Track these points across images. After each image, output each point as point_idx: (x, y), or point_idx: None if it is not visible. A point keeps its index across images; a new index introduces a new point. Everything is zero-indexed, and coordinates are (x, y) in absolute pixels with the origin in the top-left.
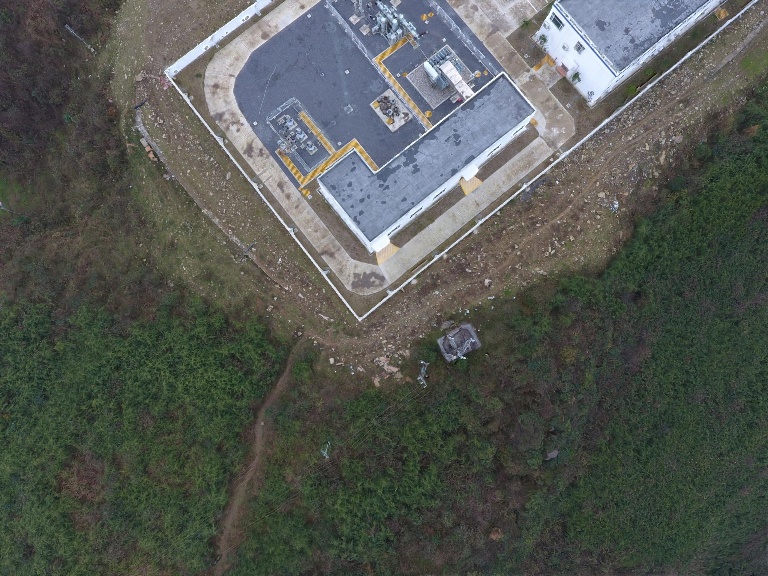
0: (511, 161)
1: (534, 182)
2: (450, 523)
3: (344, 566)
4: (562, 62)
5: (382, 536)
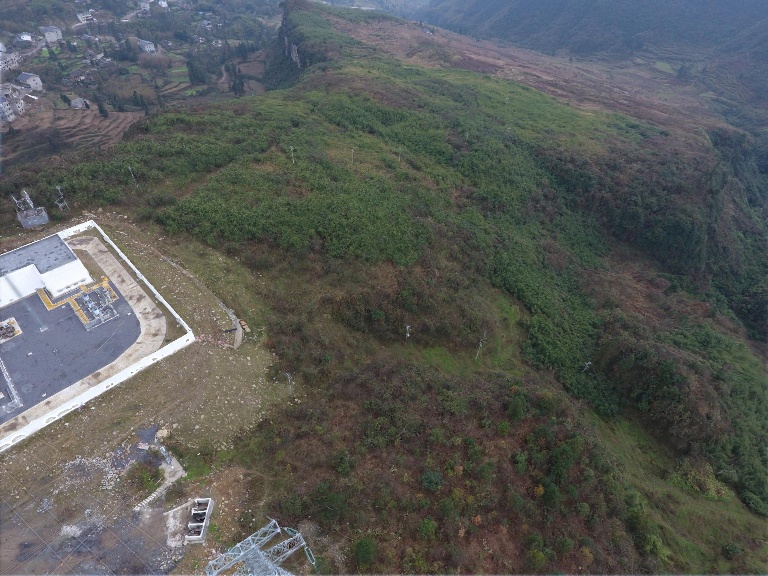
0: None
1: None
2: (76, 157)
3: None
4: None
5: None
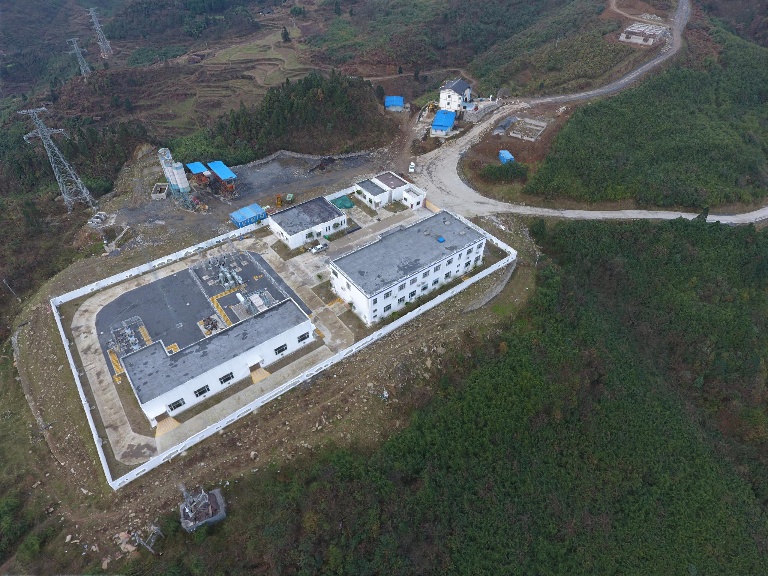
0: (298, 360)
1: (315, 375)
2: None
3: None
4: (343, 298)
5: None
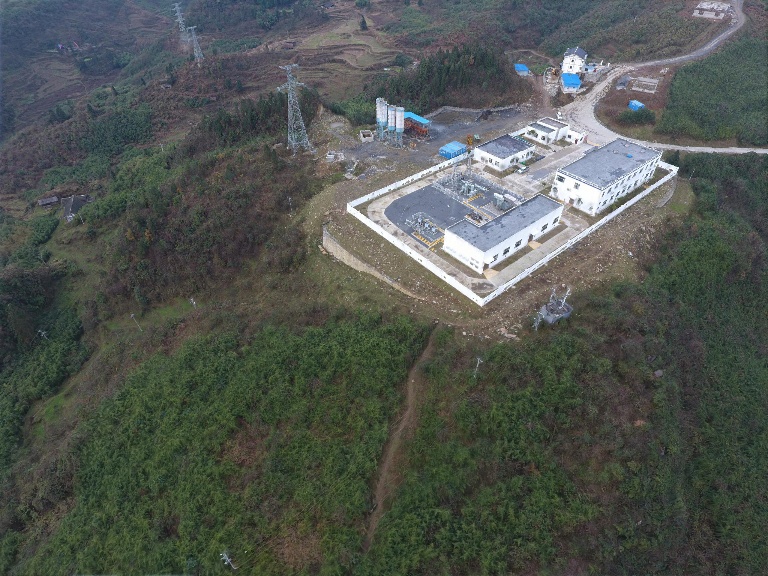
0: (556, 236)
1: (574, 244)
2: (595, 409)
3: (509, 472)
4: (569, 197)
5: (539, 430)
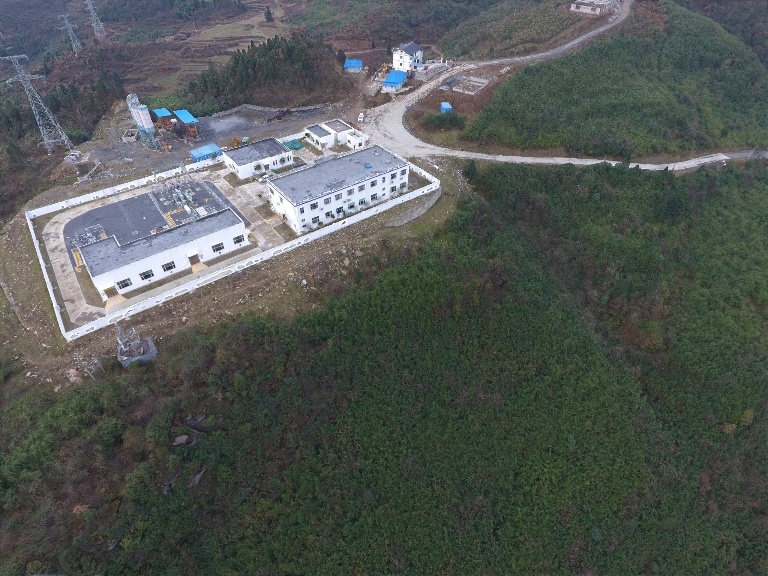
0: (233, 258)
1: (246, 268)
2: (34, 488)
3: None
4: (278, 212)
5: None
